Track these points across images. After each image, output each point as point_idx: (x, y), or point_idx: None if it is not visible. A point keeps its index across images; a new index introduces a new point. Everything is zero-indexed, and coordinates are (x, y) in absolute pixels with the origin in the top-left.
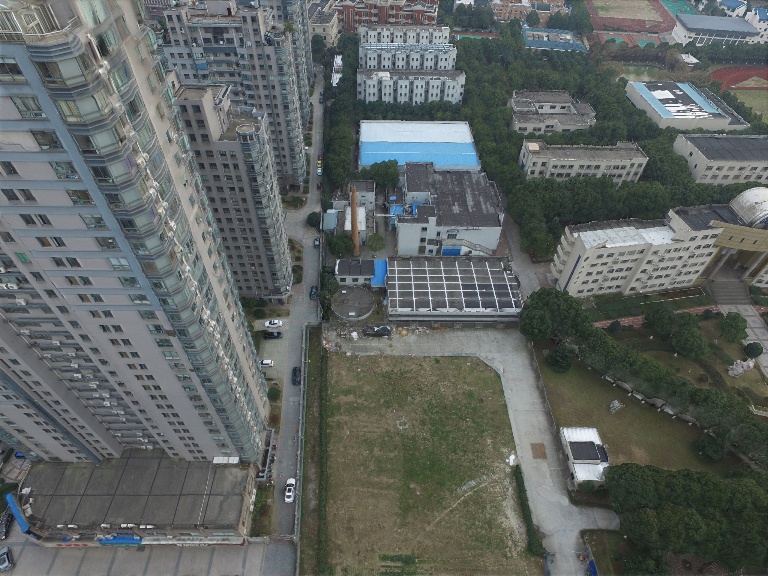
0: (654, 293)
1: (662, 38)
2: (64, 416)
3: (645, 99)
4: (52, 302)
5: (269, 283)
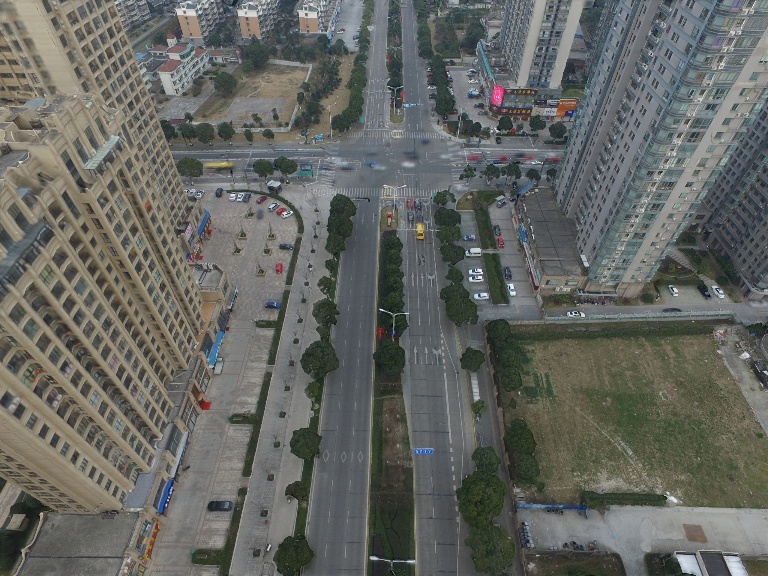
0: None
1: None
2: (583, 166)
3: None
4: (645, 80)
5: (759, 270)
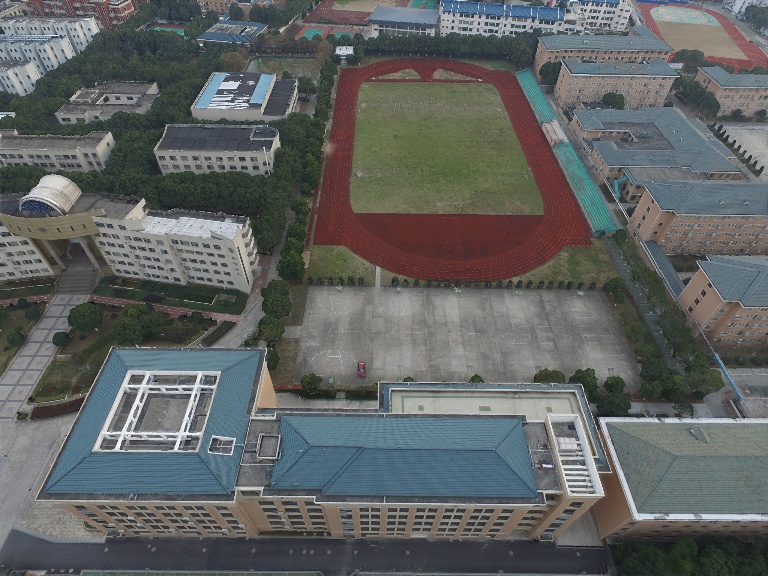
0: (4, 282)
1: (366, 30)
2: None
3: (201, 90)
4: None
5: None
